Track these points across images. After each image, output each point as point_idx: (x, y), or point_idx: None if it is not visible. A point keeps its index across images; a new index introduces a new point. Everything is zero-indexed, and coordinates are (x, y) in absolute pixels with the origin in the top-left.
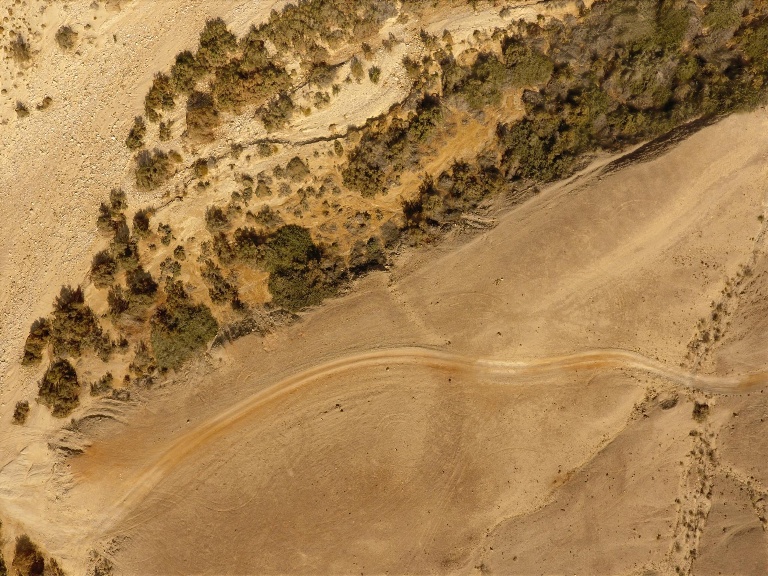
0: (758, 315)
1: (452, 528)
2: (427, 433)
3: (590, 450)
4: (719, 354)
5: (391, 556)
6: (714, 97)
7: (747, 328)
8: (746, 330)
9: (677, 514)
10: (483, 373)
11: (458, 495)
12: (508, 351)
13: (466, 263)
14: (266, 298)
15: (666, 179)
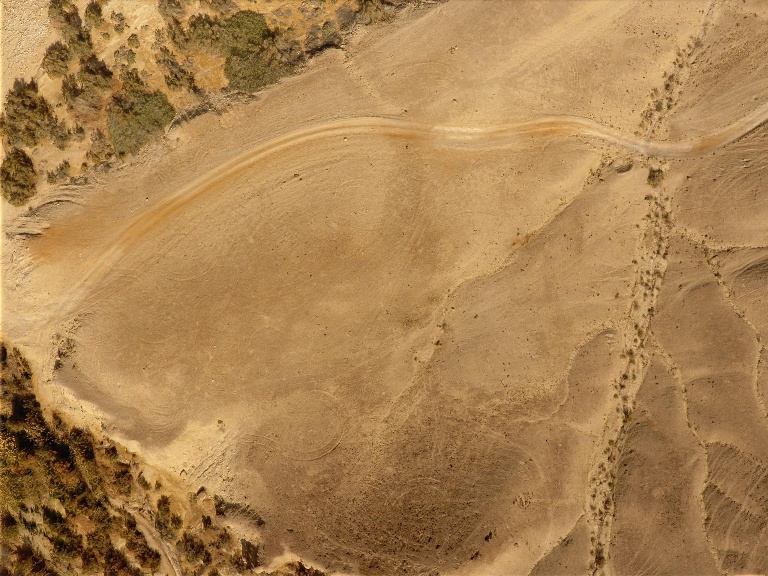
0: (709, 83)
1: (413, 289)
2: (386, 198)
3: (548, 214)
4: (672, 121)
5: (353, 317)
6: None
7: (698, 95)
8: (698, 97)
9: (635, 275)
10: (440, 139)
11: (418, 256)
12: (464, 117)
13: (420, 35)
14: (223, 83)
15: None
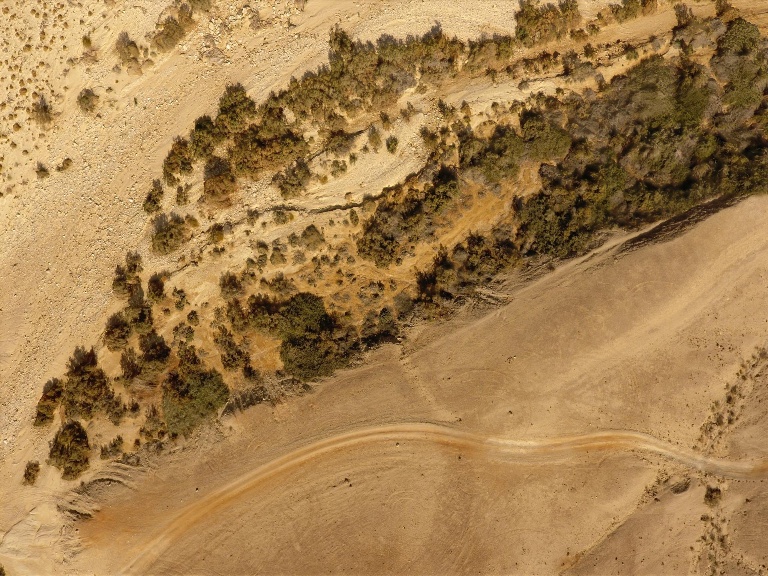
0: None
1: None
2: (435, 511)
3: (599, 533)
4: (732, 438)
5: None
6: (733, 177)
7: (762, 412)
8: (760, 414)
9: None
10: (493, 452)
11: (465, 575)
12: (519, 430)
13: (479, 339)
14: (278, 366)
15: (683, 261)
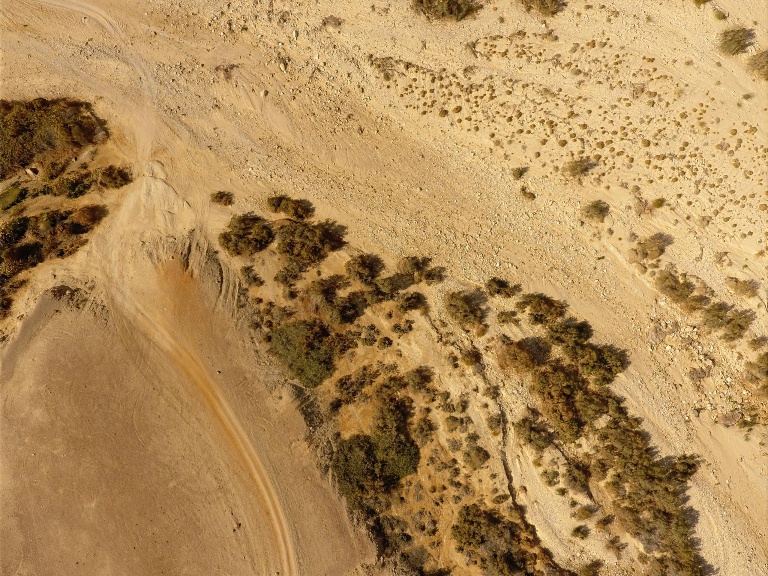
0: None
1: None
2: None
3: None
4: None
5: None
6: None
7: None
8: None
9: None
10: None
11: None
12: None
13: None
14: (345, 433)
15: None
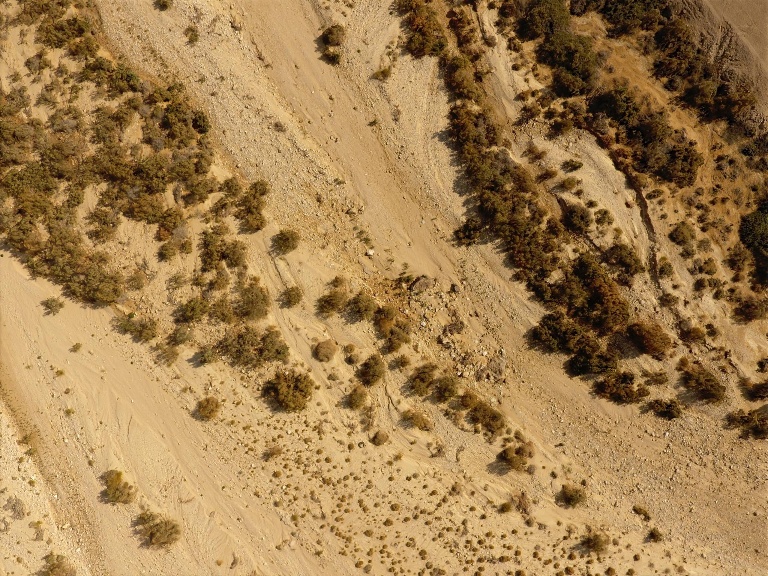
0: None
1: None
2: None
3: None
4: None
5: None
6: None
7: None
8: None
9: None
10: None
11: None
12: None
13: None
14: None
15: None
